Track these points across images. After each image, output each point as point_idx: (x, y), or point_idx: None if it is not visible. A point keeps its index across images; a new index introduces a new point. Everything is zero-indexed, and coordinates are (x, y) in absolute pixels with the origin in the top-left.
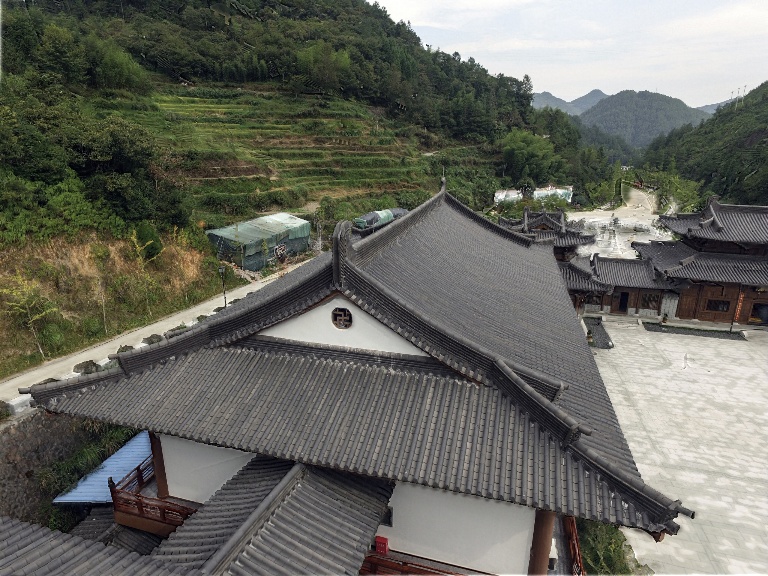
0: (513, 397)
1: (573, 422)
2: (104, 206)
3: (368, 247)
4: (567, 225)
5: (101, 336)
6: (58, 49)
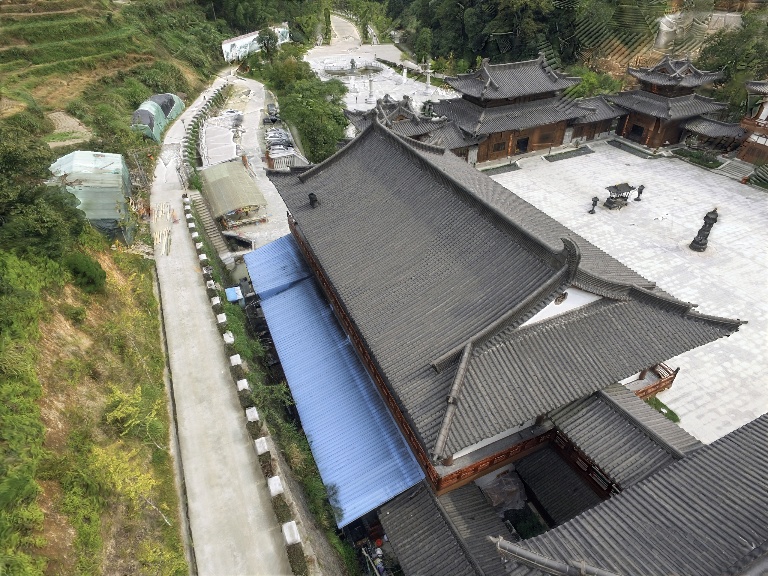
0: (647, 301)
1: (689, 304)
2: (36, 255)
3: None
4: (415, 112)
5: None
6: None
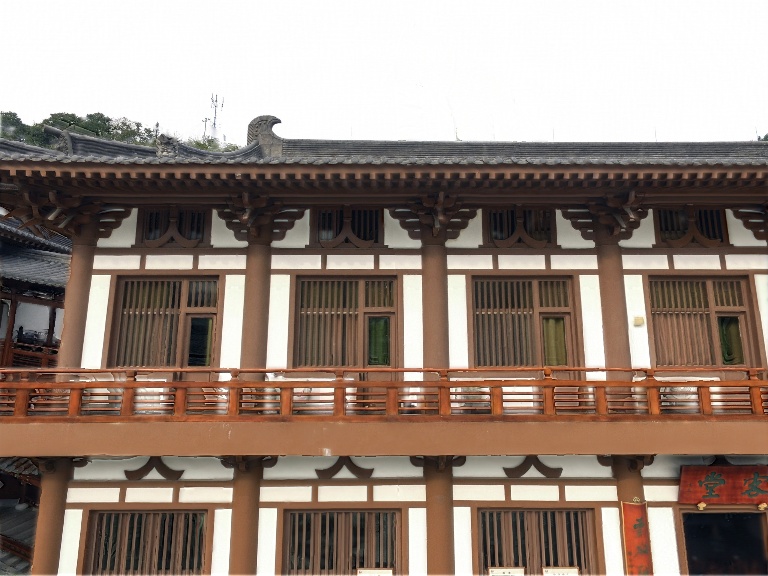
0: None
1: None
2: None
3: (318, 145)
4: None
5: None
6: None
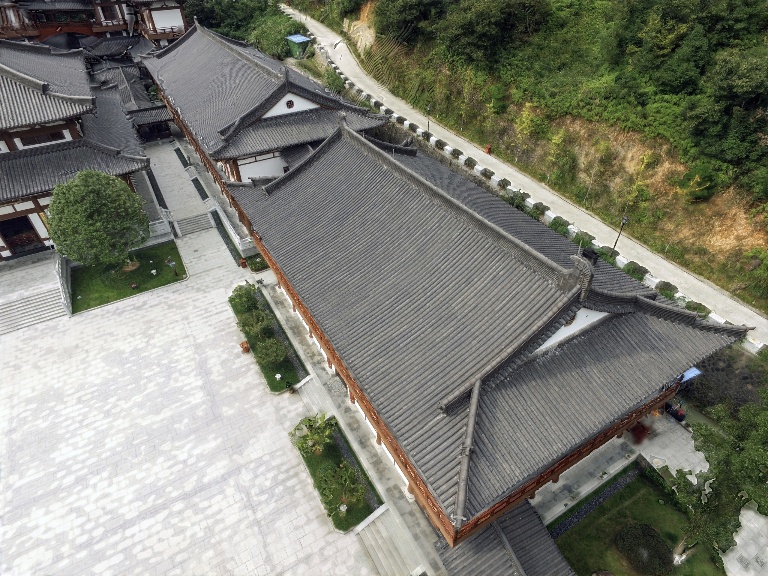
0: None
1: None
2: None
3: None
4: None
5: (578, 200)
6: None
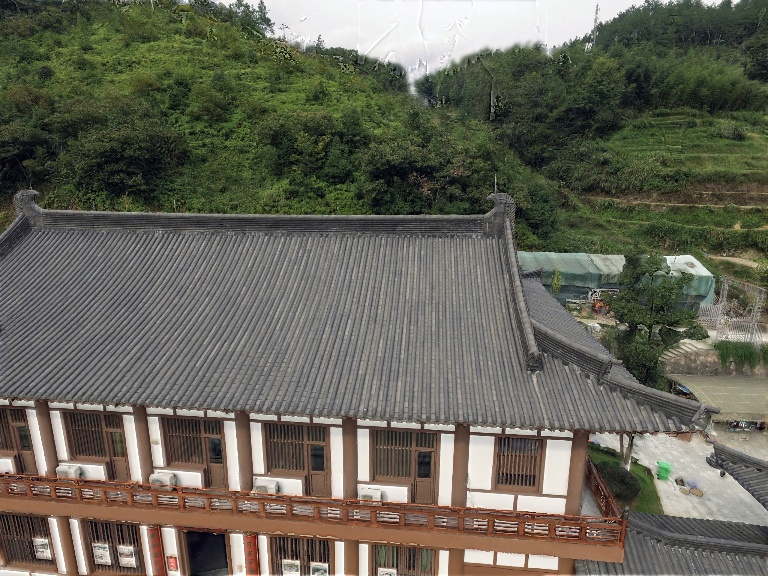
0: None
1: None
2: None
3: (69, 217)
4: None
5: None
6: (598, 80)
